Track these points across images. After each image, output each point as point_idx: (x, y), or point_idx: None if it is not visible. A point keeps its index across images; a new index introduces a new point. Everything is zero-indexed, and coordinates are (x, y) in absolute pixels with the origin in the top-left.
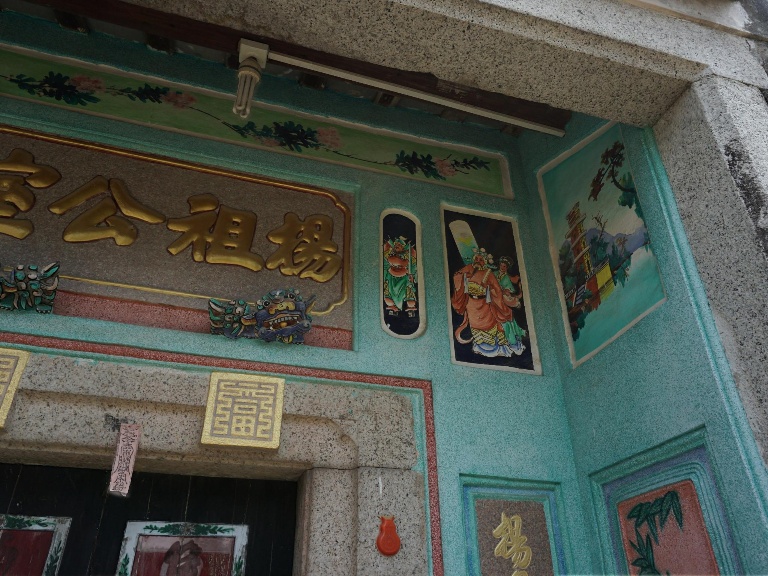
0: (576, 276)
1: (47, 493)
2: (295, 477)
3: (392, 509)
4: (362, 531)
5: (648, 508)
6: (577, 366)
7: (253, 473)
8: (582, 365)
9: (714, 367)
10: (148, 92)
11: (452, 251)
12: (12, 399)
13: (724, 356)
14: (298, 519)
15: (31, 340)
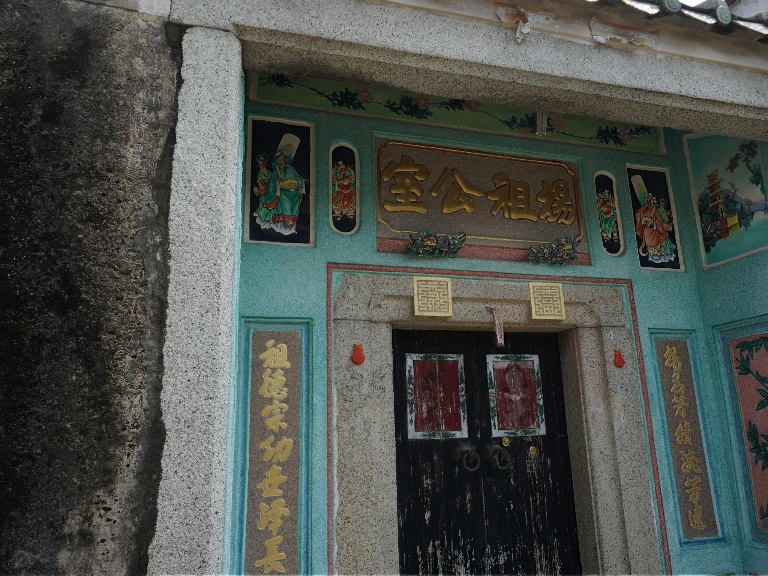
0: (711, 215)
1: (449, 343)
2: (560, 331)
3: (618, 346)
4: (607, 357)
5: (749, 344)
6: (708, 268)
7: (542, 330)
8: (713, 269)
9: None
10: (455, 102)
11: (634, 197)
12: None
13: None
14: (565, 351)
15: (451, 272)
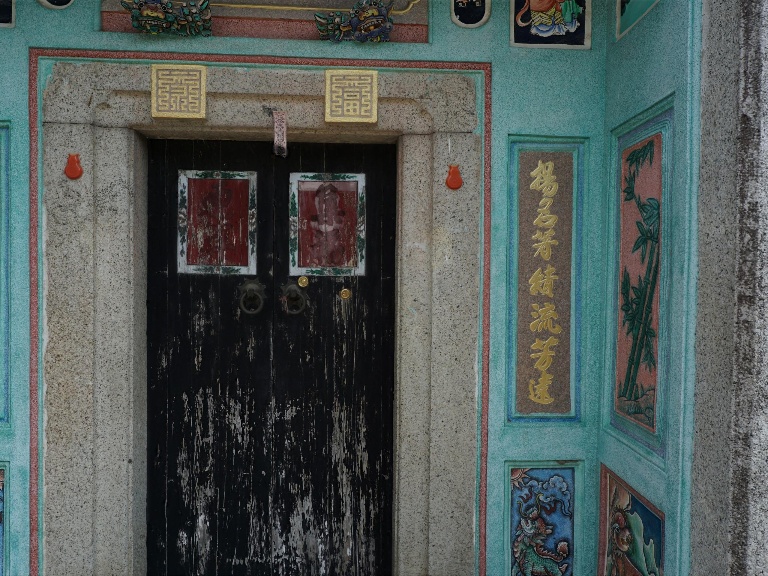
0: None
1: (239, 157)
2: (393, 141)
3: (457, 160)
4: (436, 175)
5: (638, 153)
6: (618, 40)
7: (364, 140)
8: (620, 39)
9: (690, 45)
10: None
11: None
12: (205, 100)
13: (700, 35)
14: (397, 169)
15: (205, 57)
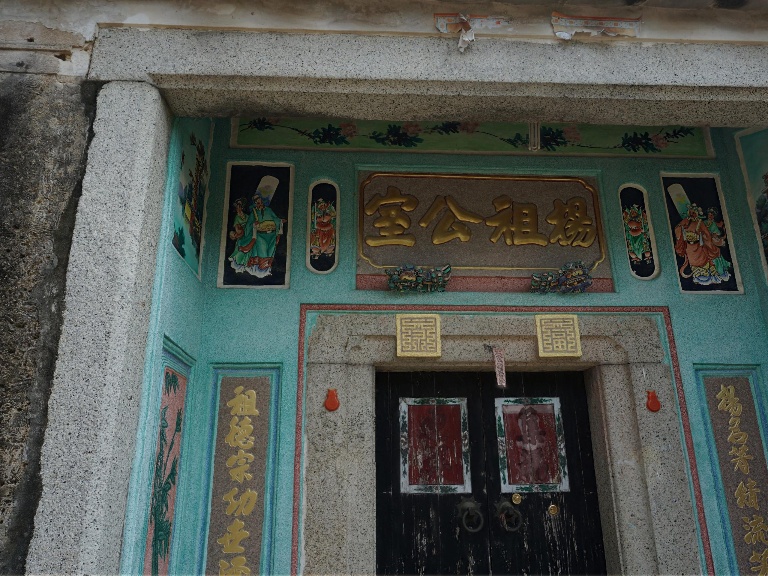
0: None
1: (451, 386)
2: (584, 369)
3: (653, 386)
4: (637, 399)
5: None
6: None
7: (560, 369)
8: None
9: None
10: (449, 126)
11: (672, 210)
12: (440, 341)
13: None
14: (590, 393)
15: (440, 308)
